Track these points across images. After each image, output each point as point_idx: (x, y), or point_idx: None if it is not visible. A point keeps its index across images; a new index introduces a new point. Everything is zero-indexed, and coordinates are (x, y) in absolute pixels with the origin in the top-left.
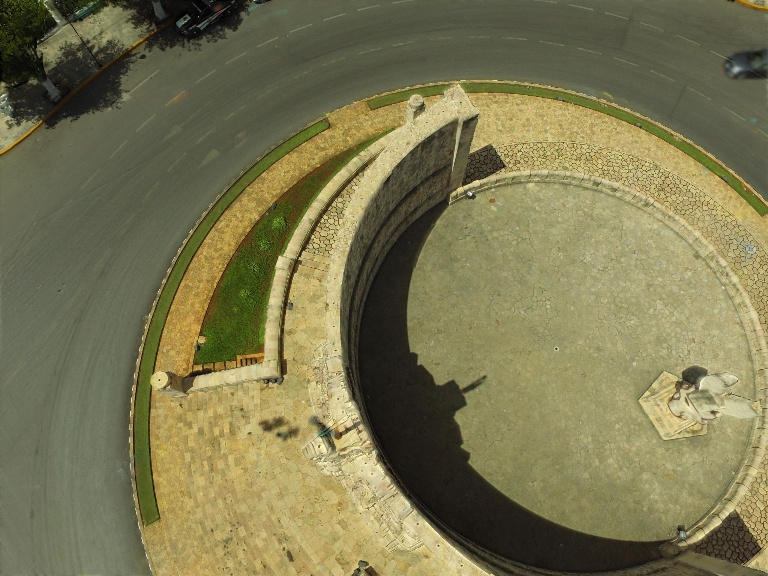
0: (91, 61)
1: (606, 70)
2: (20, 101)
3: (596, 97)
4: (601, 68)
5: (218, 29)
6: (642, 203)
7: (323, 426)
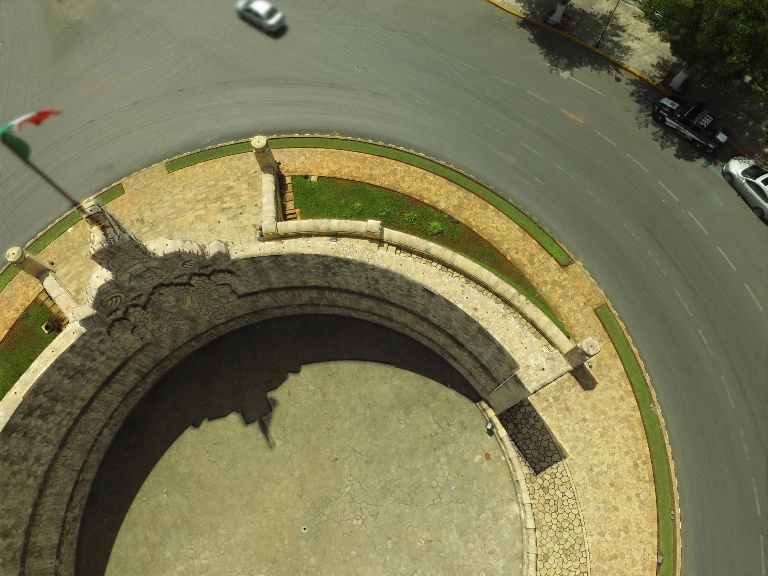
0: None
1: None
2: None
3: None
4: None
5: (673, 140)
6: None
7: None
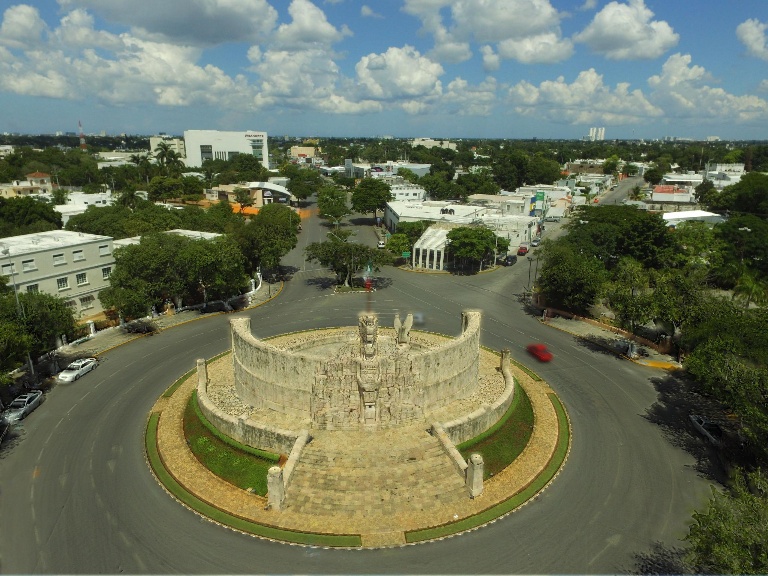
0: None
1: None
2: None
3: None
4: None
5: (10, 441)
6: (311, 344)
7: None
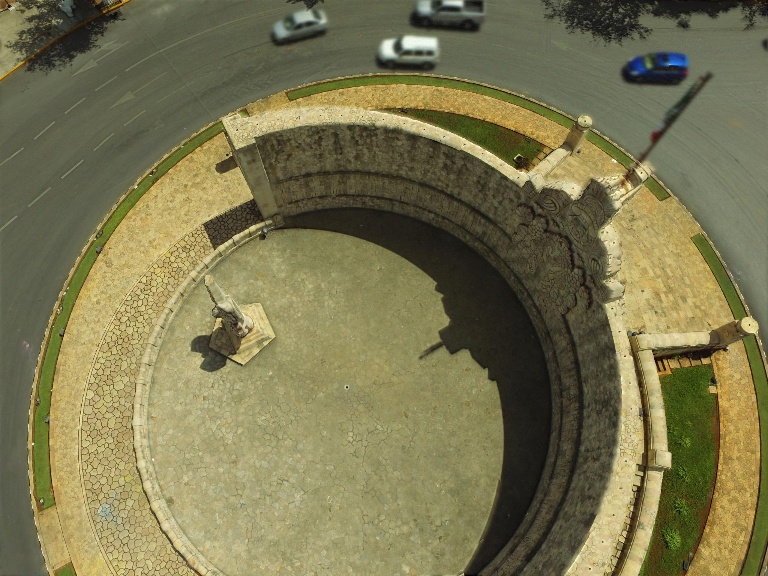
0: None
1: None
2: None
3: None
4: None
5: None
6: None
7: None
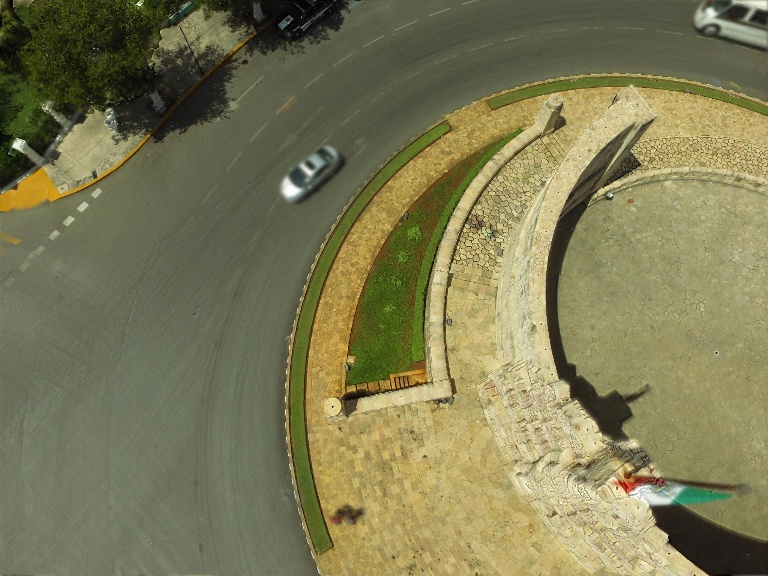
0: (192, 69)
1: (729, 58)
2: (123, 114)
3: (723, 87)
4: (724, 57)
5: (319, 29)
6: None
7: (515, 448)
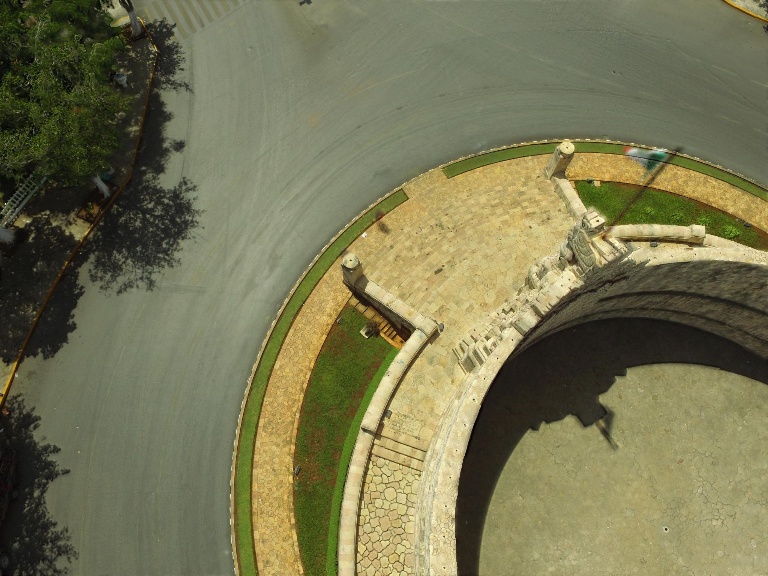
0: None
1: None
2: None
3: None
4: None
5: None
6: None
7: None
